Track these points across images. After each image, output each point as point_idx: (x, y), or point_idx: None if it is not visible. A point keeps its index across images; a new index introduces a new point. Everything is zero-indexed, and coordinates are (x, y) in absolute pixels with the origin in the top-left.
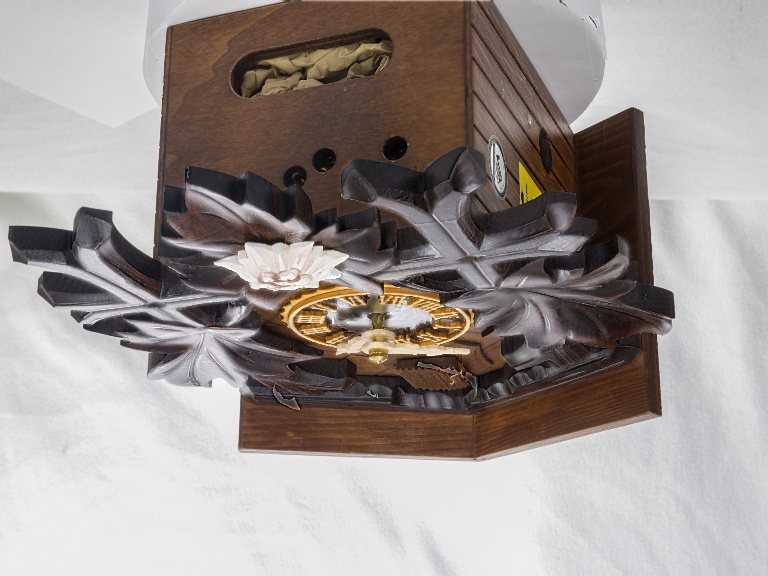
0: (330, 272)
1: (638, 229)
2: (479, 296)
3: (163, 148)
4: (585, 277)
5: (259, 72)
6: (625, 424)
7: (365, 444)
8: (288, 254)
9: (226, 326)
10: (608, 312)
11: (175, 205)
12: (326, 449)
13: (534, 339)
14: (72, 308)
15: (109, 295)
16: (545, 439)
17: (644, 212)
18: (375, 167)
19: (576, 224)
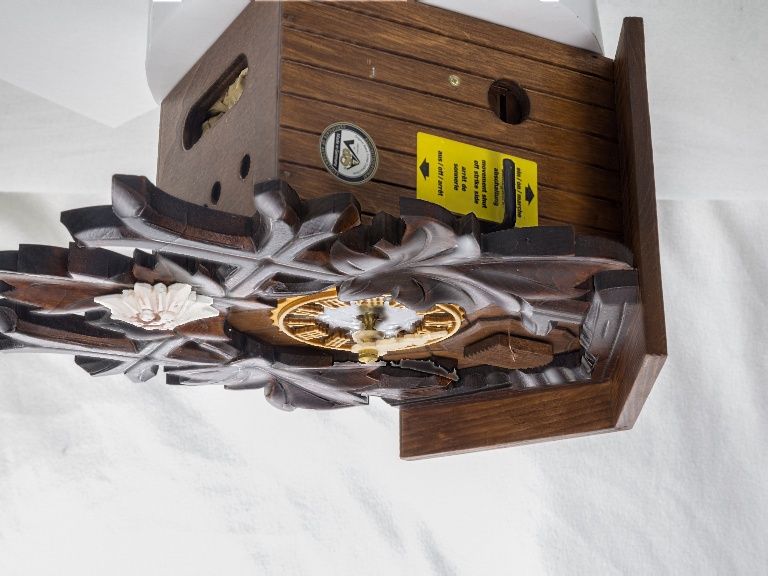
0: (192, 302)
1: (632, 152)
2: (353, 286)
3: None
4: (412, 244)
5: (211, 120)
6: (656, 370)
7: (508, 433)
8: (135, 298)
9: (236, 359)
10: (523, 264)
11: (6, 285)
12: (473, 445)
13: (501, 305)
14: (103, 374)
15: None
16: (627, 399)
17: (640, 131)
18: (77, 214)
19: (328, 202)
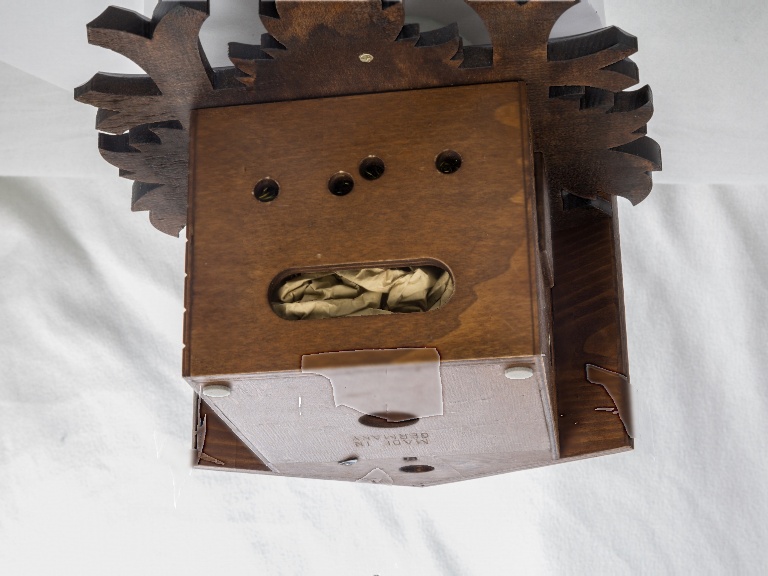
0: None
1: None
2: None
3: (529, 211)
4: None
5: None
6: None
7: None
8: None
9: None
10: None
11: None
12: None
13: None
14: None
15: (556, 41)
16: None
17: None
18: (168, 7)
19: (104, 114)
